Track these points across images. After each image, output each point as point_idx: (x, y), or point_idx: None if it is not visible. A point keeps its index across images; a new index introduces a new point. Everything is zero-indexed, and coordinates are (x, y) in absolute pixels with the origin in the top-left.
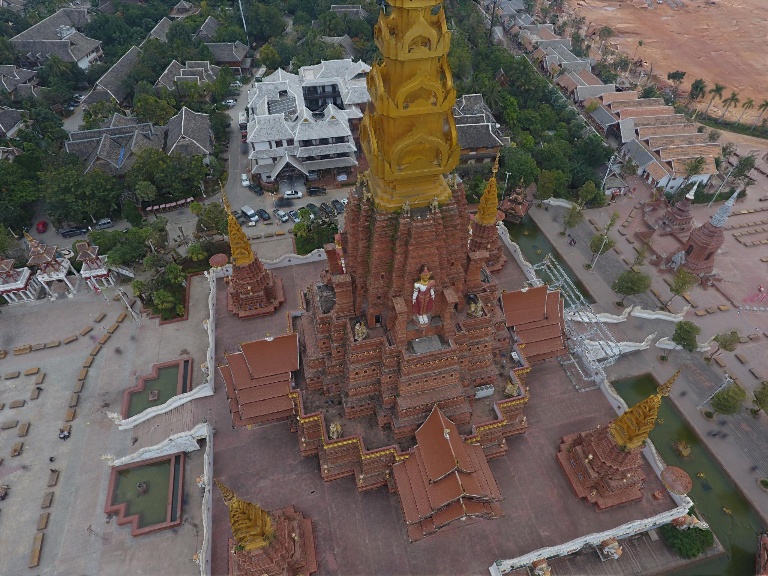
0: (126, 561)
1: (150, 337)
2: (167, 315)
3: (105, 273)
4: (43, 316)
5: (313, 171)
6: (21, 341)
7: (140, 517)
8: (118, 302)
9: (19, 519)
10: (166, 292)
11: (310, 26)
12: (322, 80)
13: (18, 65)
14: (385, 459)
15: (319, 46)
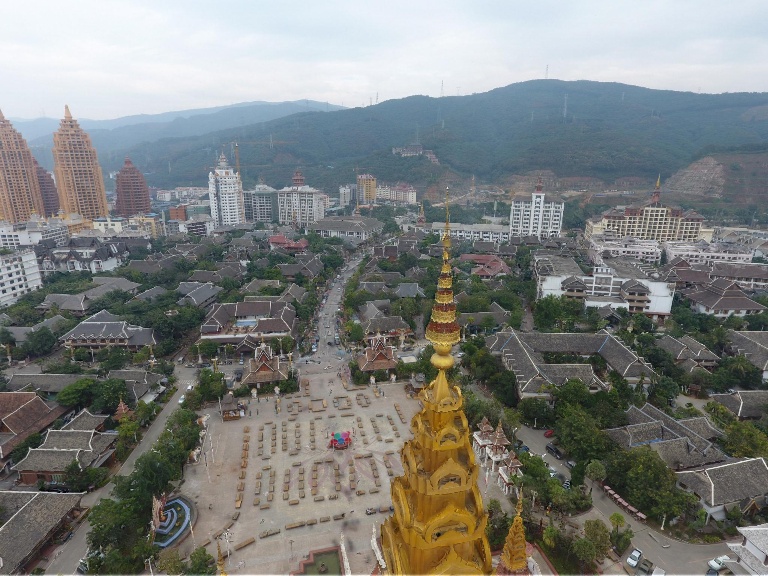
0: (275, 575)
1: None
2: None
3: (507, 482)
4: None
5: None
6: None
7: (302, 574)
8: None
9: (316, 511)
10: None
11: None
12: None
13: (718, 348)
14: None
15: None
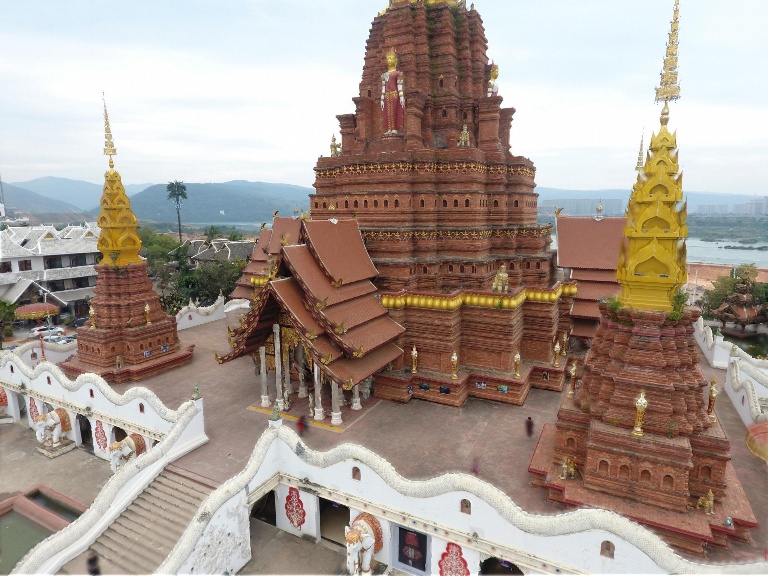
0: None
1: None
2: None
3: None
4: None
5: (64, 309)
6: None
7: None
8: None
9: None
10: None
11: None
12: None
13: None
14: (557, 315)
15: None
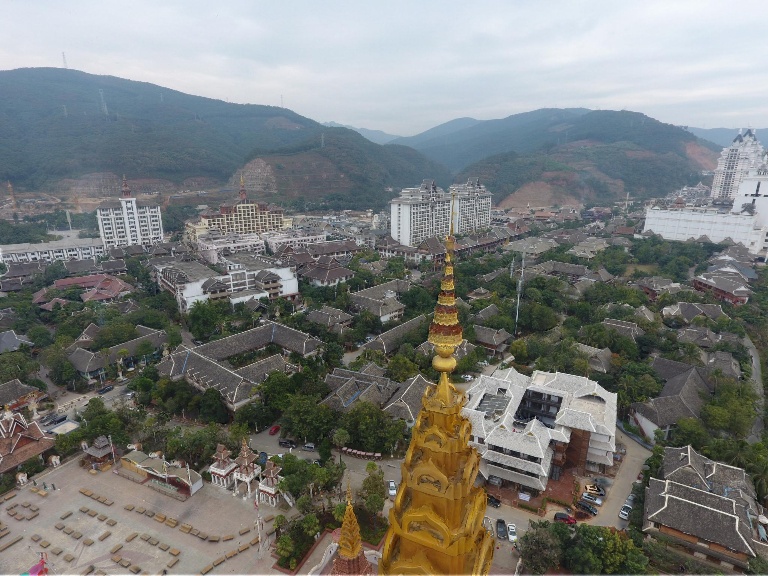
0: None
1: (258, 575)
2: (282, 562)
3: (273, 493)
4: (219, 506)
5: None
6: (192, 519)
7: None
8: (265, 524)
9: None
10: (296, 538)
11: (577, 330)
12: (549, 389)
13: (347, 310)
14: None
15: (571, 353)
